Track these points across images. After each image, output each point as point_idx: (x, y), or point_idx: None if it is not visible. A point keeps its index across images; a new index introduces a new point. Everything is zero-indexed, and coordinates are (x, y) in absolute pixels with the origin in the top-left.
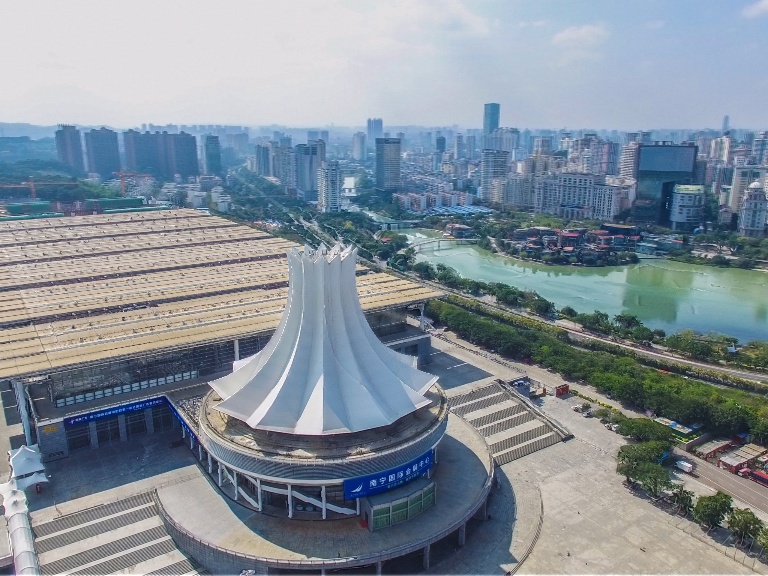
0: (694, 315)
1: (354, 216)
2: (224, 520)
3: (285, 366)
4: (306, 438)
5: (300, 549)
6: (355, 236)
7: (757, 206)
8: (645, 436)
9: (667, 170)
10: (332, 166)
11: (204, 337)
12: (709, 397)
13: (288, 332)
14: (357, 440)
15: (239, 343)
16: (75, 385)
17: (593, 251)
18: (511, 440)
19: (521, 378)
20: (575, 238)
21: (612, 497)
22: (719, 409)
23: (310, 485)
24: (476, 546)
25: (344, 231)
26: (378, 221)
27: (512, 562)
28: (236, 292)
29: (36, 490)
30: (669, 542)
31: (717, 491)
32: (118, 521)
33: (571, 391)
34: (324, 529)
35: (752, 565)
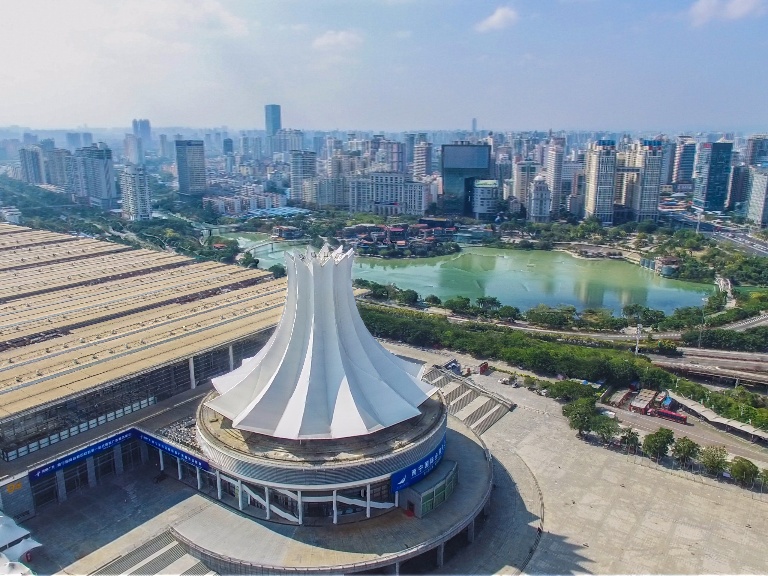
0: (528, 292)
1: (173, 223)
2: (271, 541)
3: (298, 374)
4: (344, 441)
5: (367, 549)
6: (186, 244)
7: (543, 196)
8: (575, 395)
9: (467, 167)
10: (139, 171)
11: (165, 358)
12: (600, 356)
13: (295, 339)
14: (390, 434)
15: (194, 361)
16: (28, 432)
17: (423, 243)
18: (471, 417)
19: (452, 361)
20: (401, 232)
21: (576, 450)
22: (616, 365)
23: (360, 486)
24: (499, 513)
25: (171, 239)
26: (198, 227)
27: (536, 519)
28: (150, 309)
29: (26, 559)
30: (637, 476)
31: (641, 430)
32: (147, 570)
33: (490, 367)
34: (376, 526)
35: (701, 480)
